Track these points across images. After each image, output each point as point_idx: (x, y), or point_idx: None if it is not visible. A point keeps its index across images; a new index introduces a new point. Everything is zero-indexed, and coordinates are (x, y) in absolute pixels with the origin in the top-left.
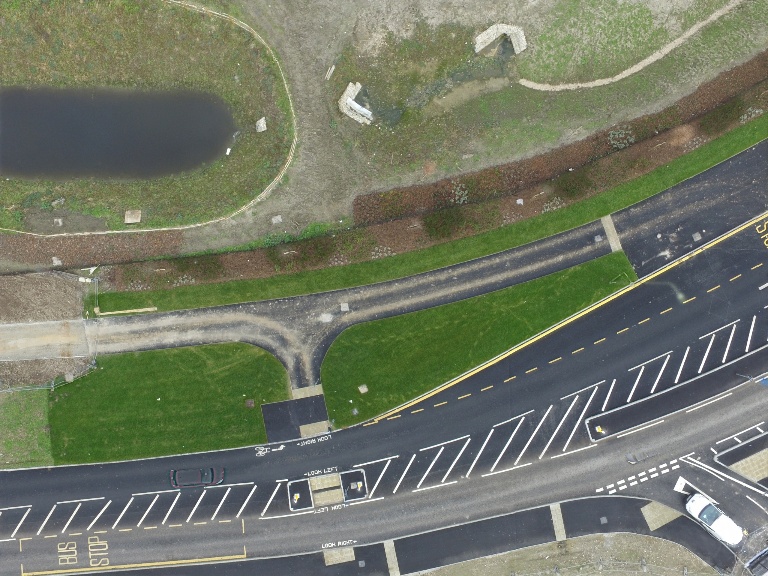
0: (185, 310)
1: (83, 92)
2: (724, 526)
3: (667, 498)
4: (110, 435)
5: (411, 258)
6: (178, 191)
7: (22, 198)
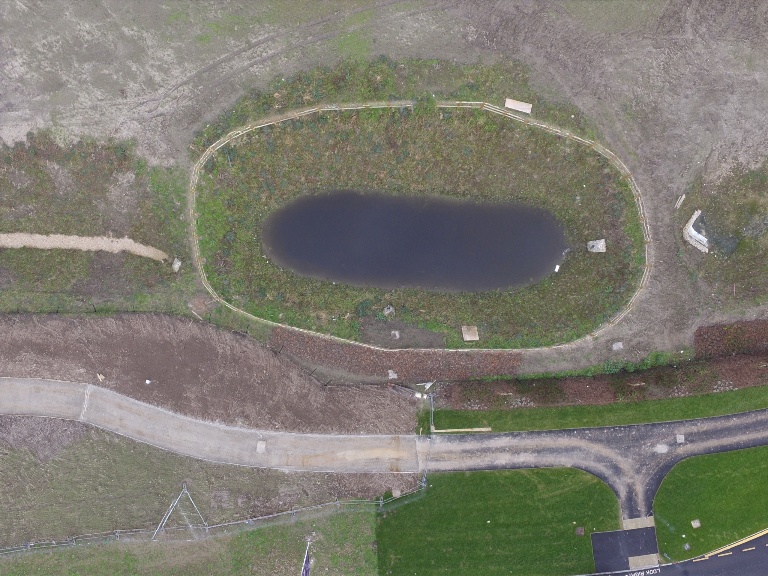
0: (519, 432)
1: (414, 199)
2: None
3: None
4: (438, 556)
5: (752, 394)
6: (509, 307)
7: (354, 305)
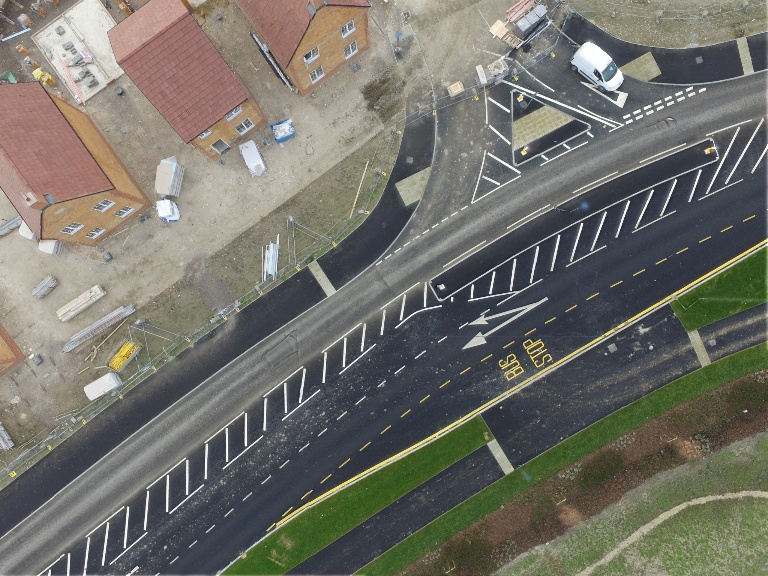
0: None
1: None
2: (601, 60)
3: (634, 85)
4: None
5: None
6: None
7: None
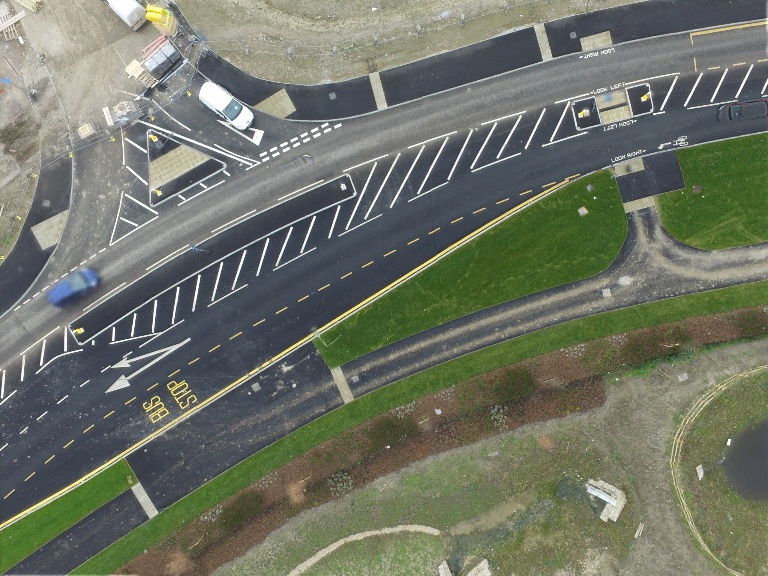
0: None
1: None
2: (219, 100)
3: (270, 123)
4: None
5: (544, 347)
6: None
7: None
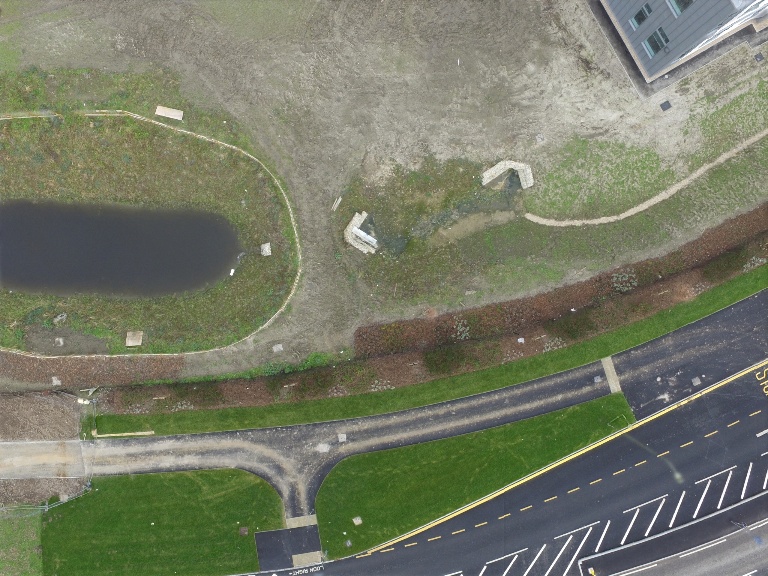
0: (182, 435)
1: (90, 207)
2: None
3: None
4: (102, 558)
5: (410, 392)
6: (180, 312)
7: (24, 314)
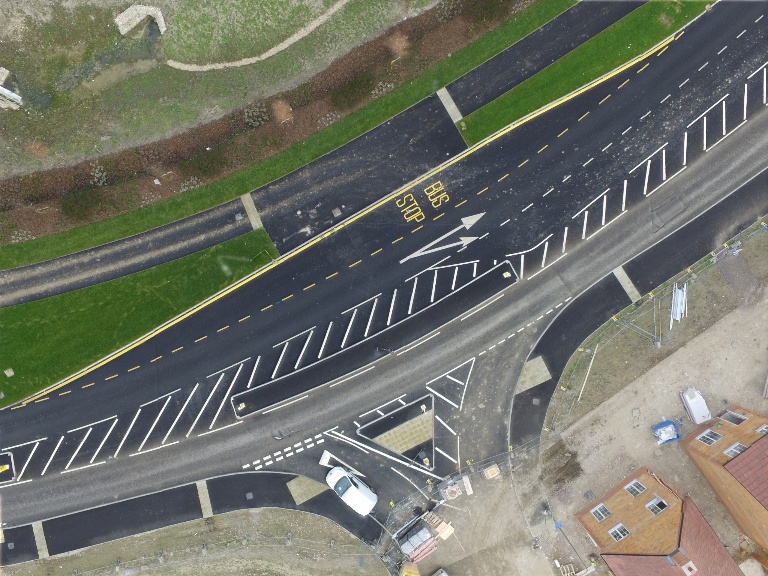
0: None
1: None
2: (353, 498)
3: (313, 472)
4: None
5: (52, 241)
6: None
7: None
